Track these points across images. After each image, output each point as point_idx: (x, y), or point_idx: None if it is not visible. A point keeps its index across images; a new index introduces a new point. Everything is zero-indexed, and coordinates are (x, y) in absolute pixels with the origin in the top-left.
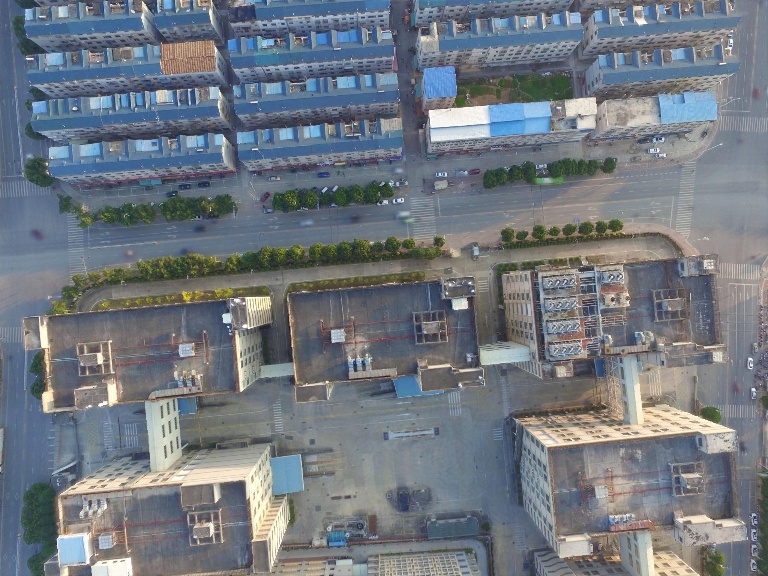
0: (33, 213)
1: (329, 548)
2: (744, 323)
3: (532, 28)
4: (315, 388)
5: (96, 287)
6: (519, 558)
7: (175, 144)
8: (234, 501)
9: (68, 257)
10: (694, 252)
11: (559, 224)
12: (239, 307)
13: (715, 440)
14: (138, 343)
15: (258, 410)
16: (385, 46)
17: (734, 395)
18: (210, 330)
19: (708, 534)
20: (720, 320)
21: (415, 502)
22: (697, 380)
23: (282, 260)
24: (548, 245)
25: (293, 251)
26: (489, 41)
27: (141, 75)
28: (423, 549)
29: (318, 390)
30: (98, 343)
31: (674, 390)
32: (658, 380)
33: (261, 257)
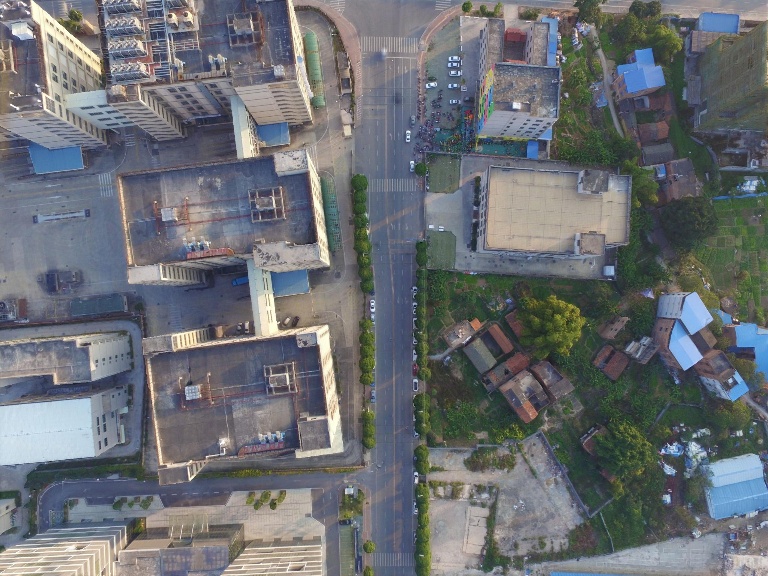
0: None
1: None
2: (402, 96)
3: None
4: None
5: None
6: None
7: None
8: None
9: None
10: (349, 26)
11: None
12: None
13: (283, 158)
14: None
15: None
16: None
17: (393, 169)
18: None
19: (279, 254)
20: (291, 40)
21: None
22: (353, 153)
23: None
24: None
25: None
26: None
27: None
28: (76, 332)
29: None
30: None
31: (331, 165)
32: (315, 156)
33: None
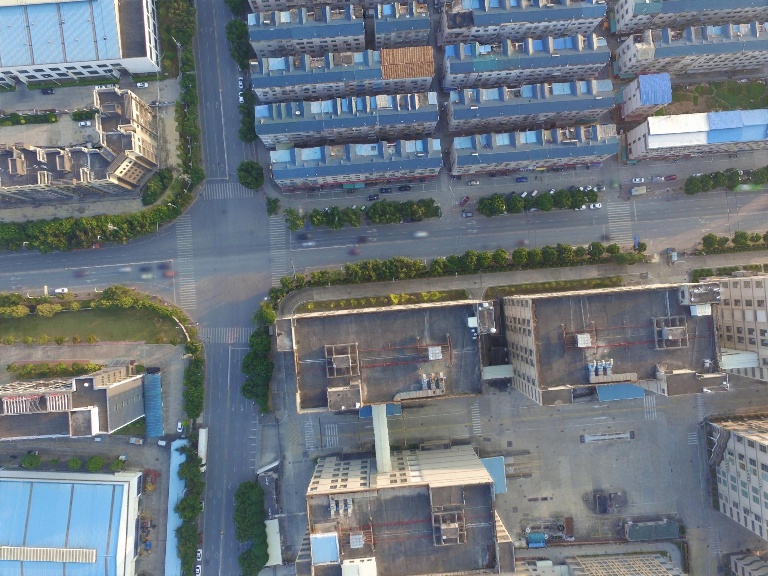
0: (236, 215)
1: (527, 549)
2: None
3: (746, 36)
4: (560, 392)
5: (299, 289)
6: (713, 561)
7: (391, 148)
8: (475, 502)
9: (270, 259)
10: None
11: (754, 230)
12: (486, 311)
13: None
14: (383, 345)
15: (456, 412)
16: (602, 53)
17: None
18: (453, 333)
19: None
20: None
21: (614, 505)
22: None
23: (488, 264)
24: (743, 251)
25: (501, 255)
26: (704, 49)
27: (361, 80)
28: (618, 551)
29: (563, 394)
30: (346, 345)
31: None
32: None
33: (469, 261)
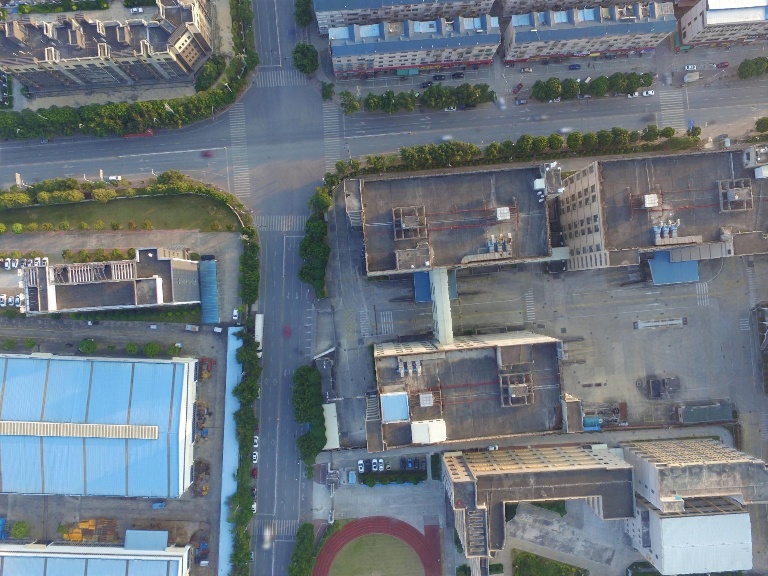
0: (289, 103)
1: (582, 434)
2: None
3: None
4: (627, 252)
5: (353, 176)
6: (765, 446)
7: (449, 27)
8: (542, 365)
9: (324, 147)
10: None
11: None
12: (554, 172)
13: None
14: (449, 209)
15: (511, 299)
16: None
17: None
18: (519, 197)
19: None
20: None
21: None
22: None
23: (544, 147)
24: None
25: (557, 137)
26: None
27: None
28: (671, 436)
29: (630, 254)
30: (414, 207)
31: None
32: None
33: (525, 143)
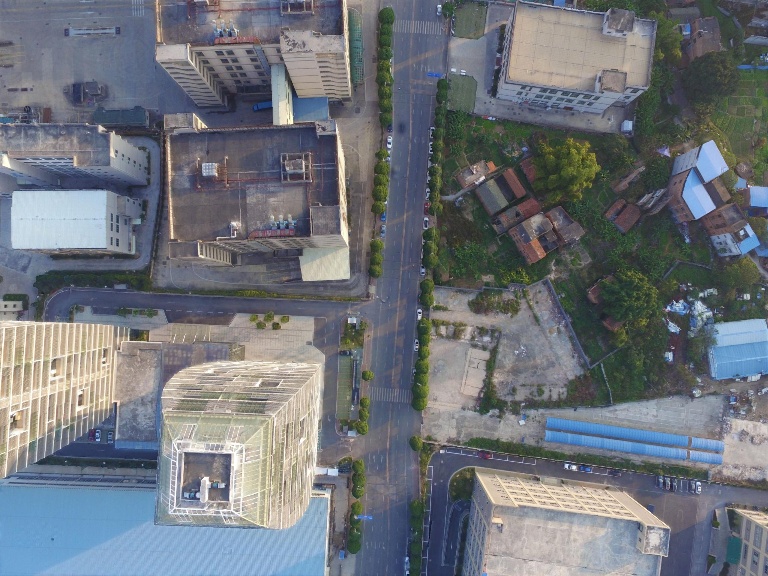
0: None
1: None
2: None
3: None
4: None
5: None
6: None
7: None
8: None
9: None
10: None
11: None
12: None
13: None
14: None
15: None
16: None
17: (420, 11)
18: None
19: (305, 42)
20: None
21: (87, 92)
22: None
23: None
24: None
25: None
26: None
27: None
28: None
29: None
30: None
31: (360, 3)
32: None
33: None
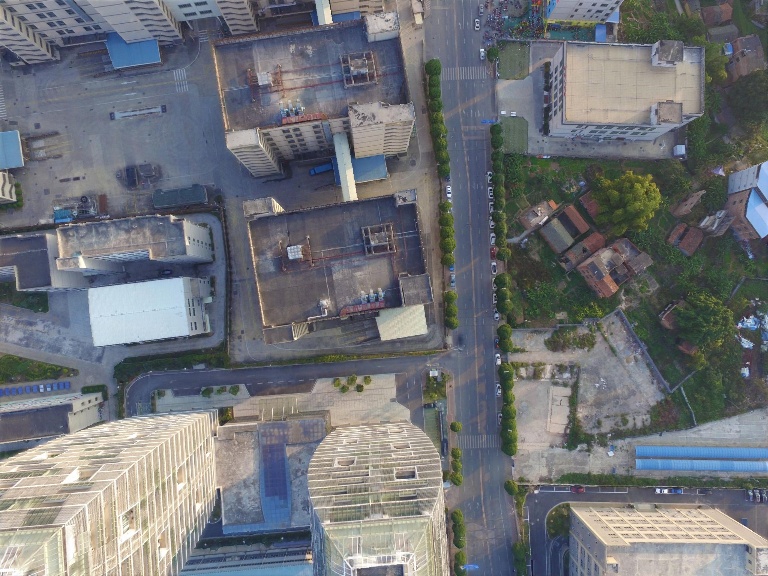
0: None
1: None
2: None
3: None
4: None
5: None
6: None
7: None
8: None
9: None
10: None
11: None
12: None
13: (376, 20)
14: None
15: None
16: None
17: (464, 57)
18: None
19: (375, 114)
20: None
21: None
22: (424, 43)
23: None
24: None
25: None
26: None
27: None
28: None
29: None
30: None
31: None
32: None
33: None
